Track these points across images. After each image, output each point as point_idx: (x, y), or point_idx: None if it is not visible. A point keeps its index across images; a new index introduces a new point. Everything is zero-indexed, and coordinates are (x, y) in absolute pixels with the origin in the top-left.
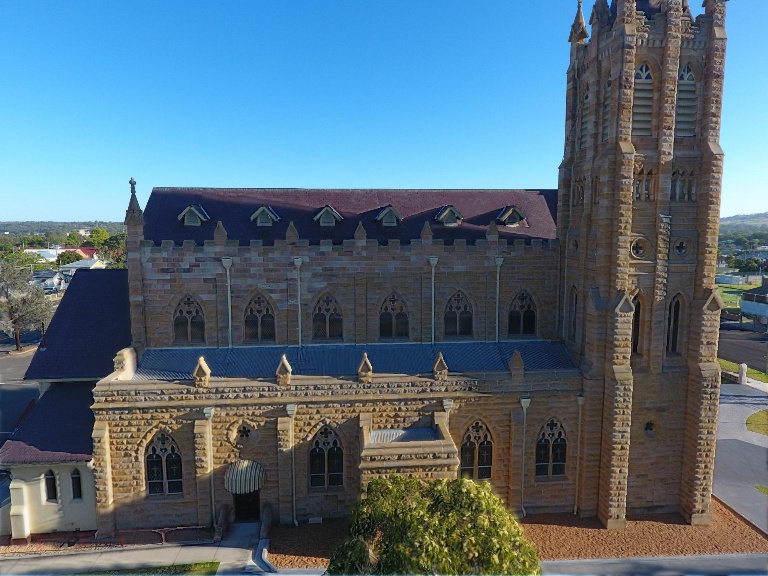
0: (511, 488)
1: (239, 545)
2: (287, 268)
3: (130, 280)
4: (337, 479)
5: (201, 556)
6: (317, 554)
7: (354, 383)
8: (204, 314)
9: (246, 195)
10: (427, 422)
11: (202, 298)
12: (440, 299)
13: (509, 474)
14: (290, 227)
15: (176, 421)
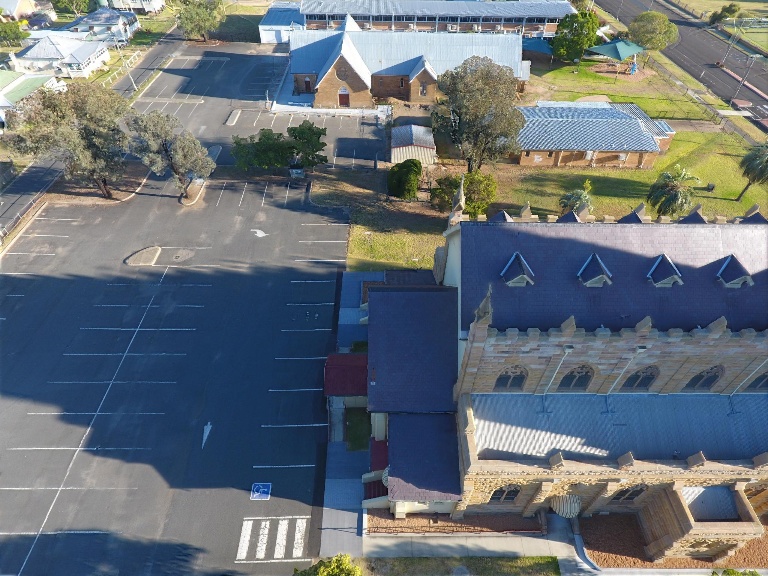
0: (763, 509)
1: (562, 539)
2: (626, 352)
3: (471, 359)
4: (630, 498)
5: (540, 549)
6: (620, 552)
7: (683, 470)
8: (529, 376)
9: (569, 236)
10: (726, 485)
11: (532, 367)
12: (762, 370)
13: (767, 503)
14: (648, 326)
15: (527, 482)
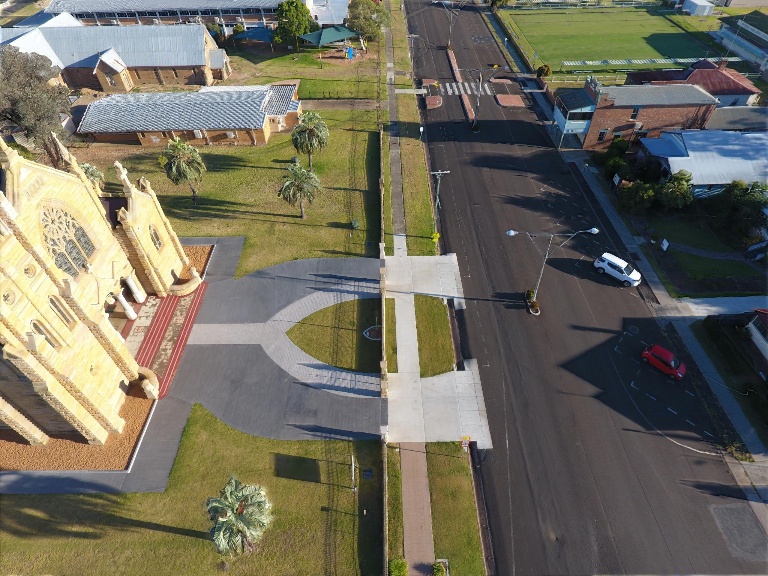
0: None
1: None
2: None
3: None
4: None
5: None
6: None
7: None
8: None
9: None
10: None
11: None
12: None
13: None
14: None
15: None
